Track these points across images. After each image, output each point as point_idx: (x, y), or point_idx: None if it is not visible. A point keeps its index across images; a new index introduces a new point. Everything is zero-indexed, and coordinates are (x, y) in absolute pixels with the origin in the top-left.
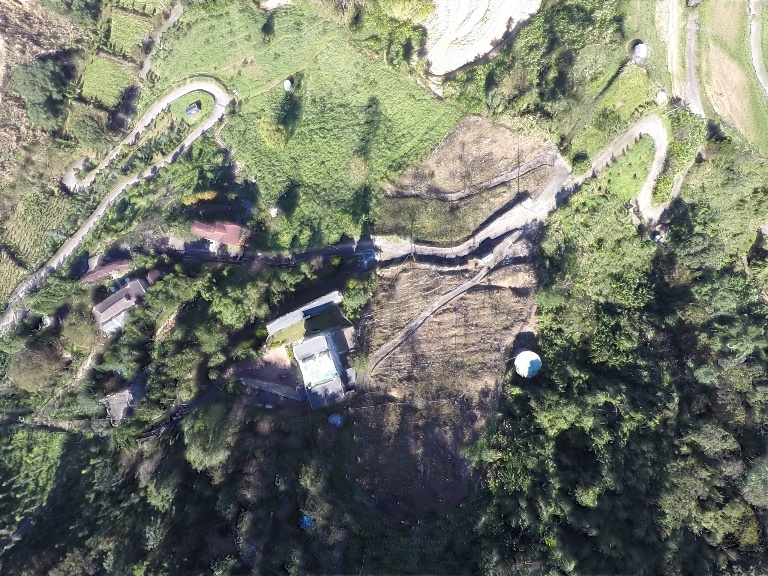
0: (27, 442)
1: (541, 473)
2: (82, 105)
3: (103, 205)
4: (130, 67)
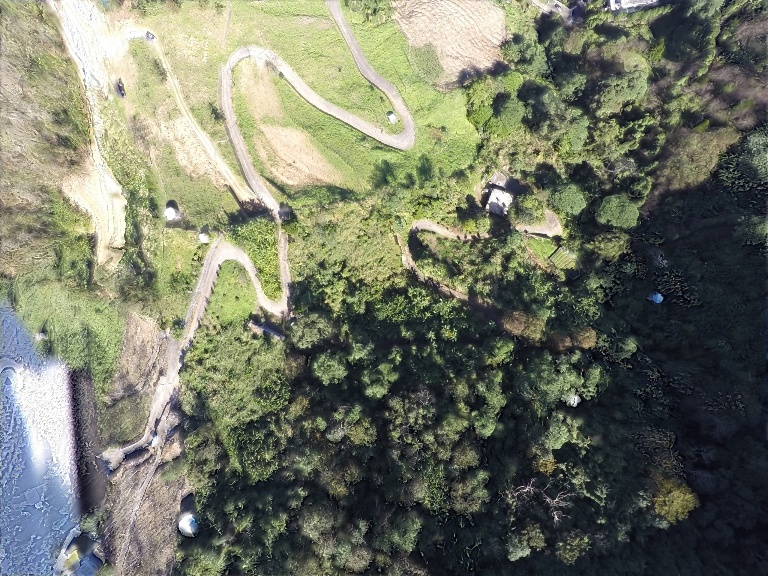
0: None
1: None
2: None
3: None
4: None
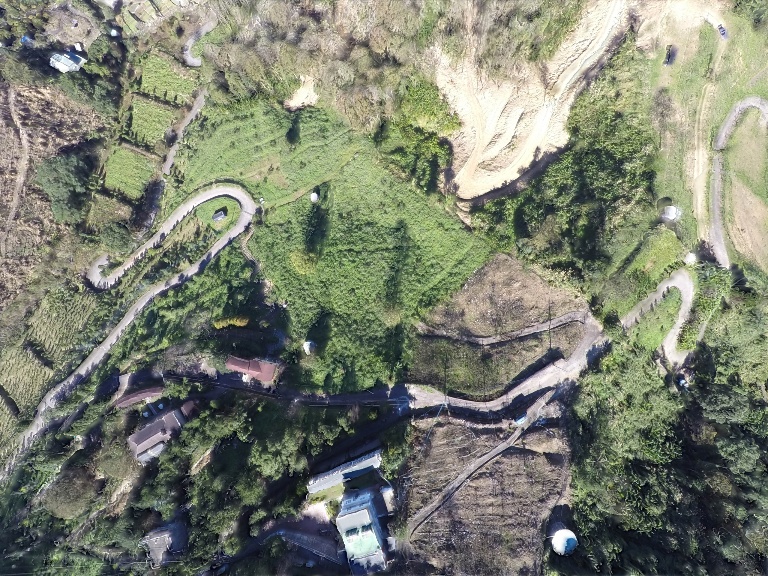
0: (63, 568)
1: None
2: (105, 198)
3: (131, 313)
4: (153, 159)
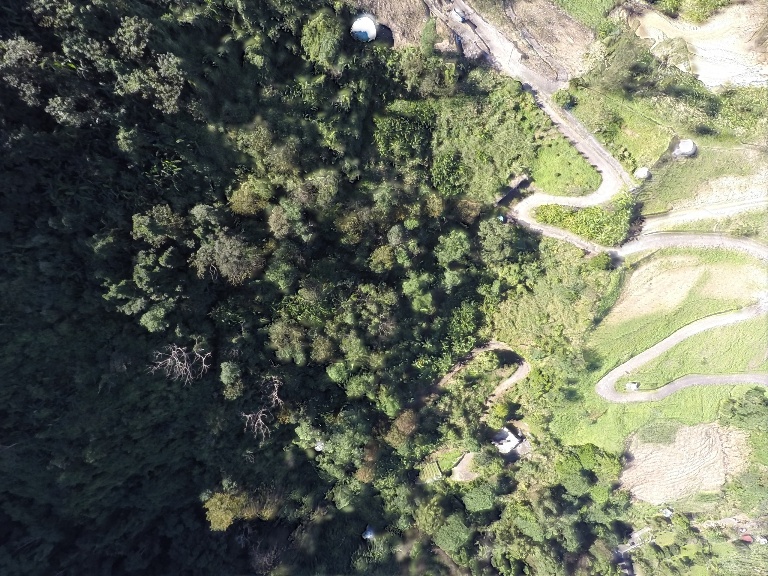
0: None
1: (267, 13)
2: None
3: None
4: None
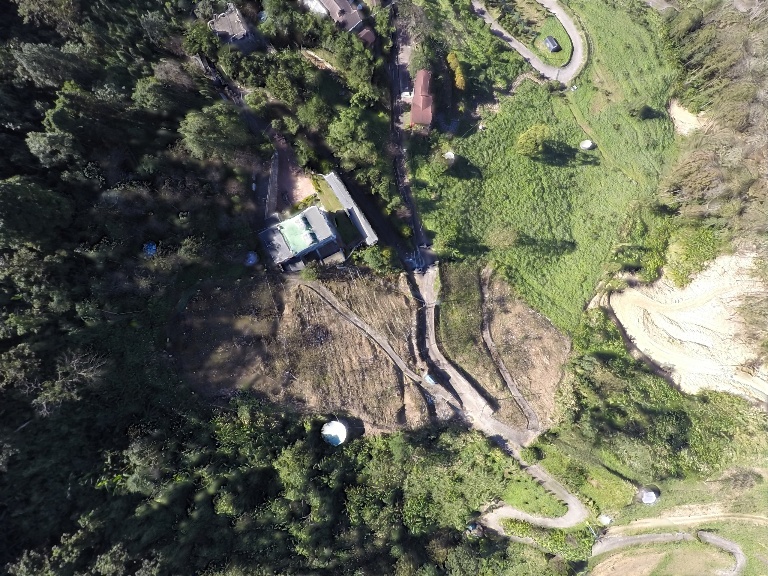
0: None
1: (236, 461)
2: None
3: None
4: None
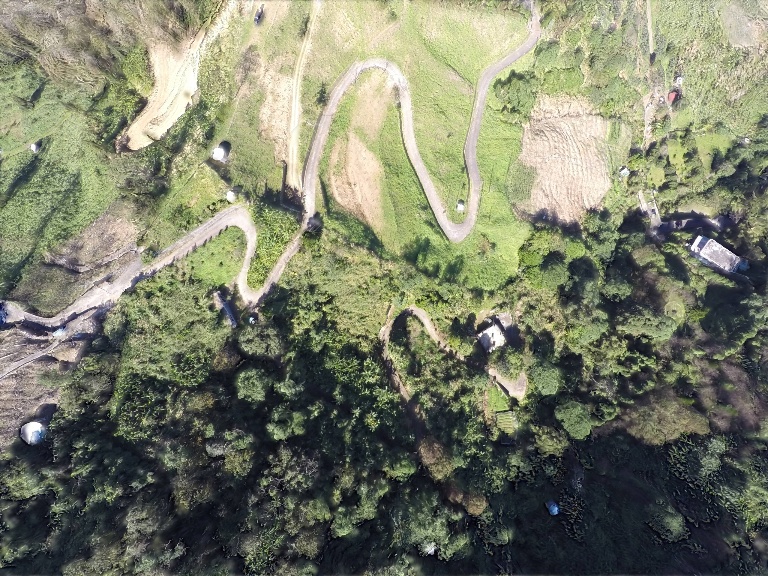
0: None
1: None
2: None
3: None
4: None
